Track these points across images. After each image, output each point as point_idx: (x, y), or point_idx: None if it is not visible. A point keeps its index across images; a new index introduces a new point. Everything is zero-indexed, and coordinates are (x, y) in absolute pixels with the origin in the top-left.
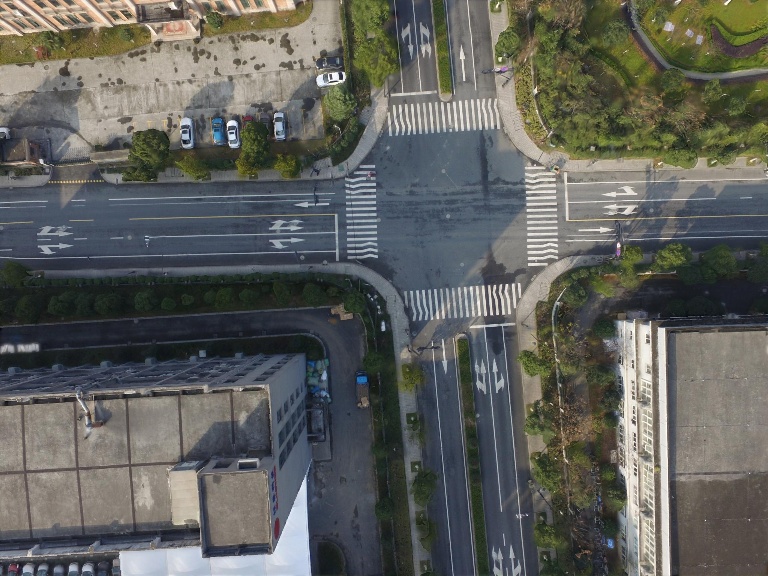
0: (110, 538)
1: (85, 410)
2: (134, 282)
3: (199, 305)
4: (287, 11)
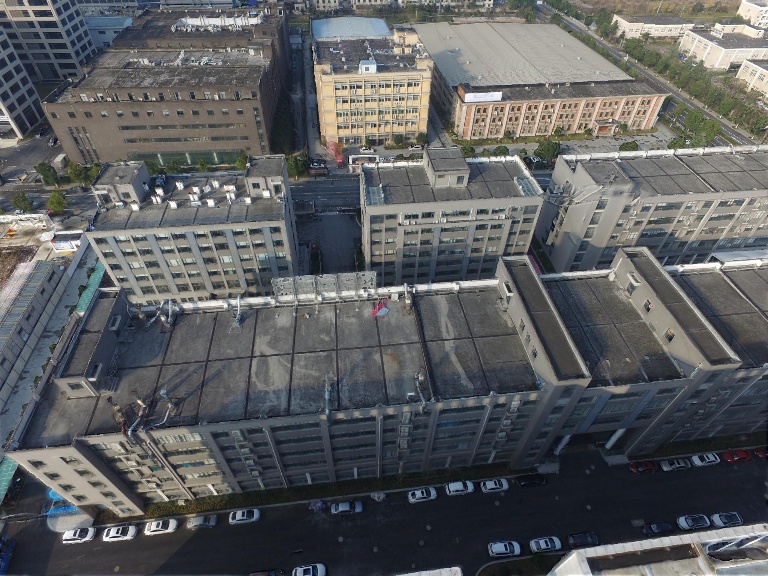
0: None
1: (734, 153)
2: None
3: None
4: (648, 129)
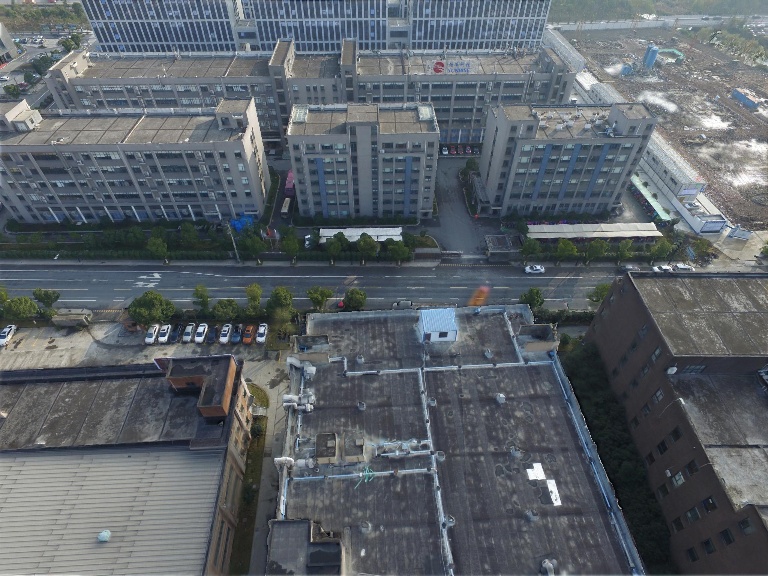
0: (85, 116)
1: (59, 142)
2: None
3: None
4: None
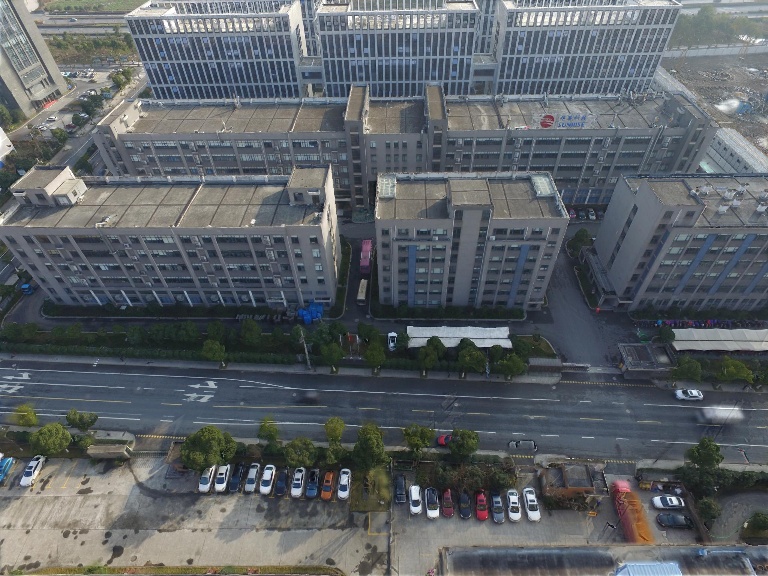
0: (134, 184)
1: (104, 223)
2: None
3: None
4: None
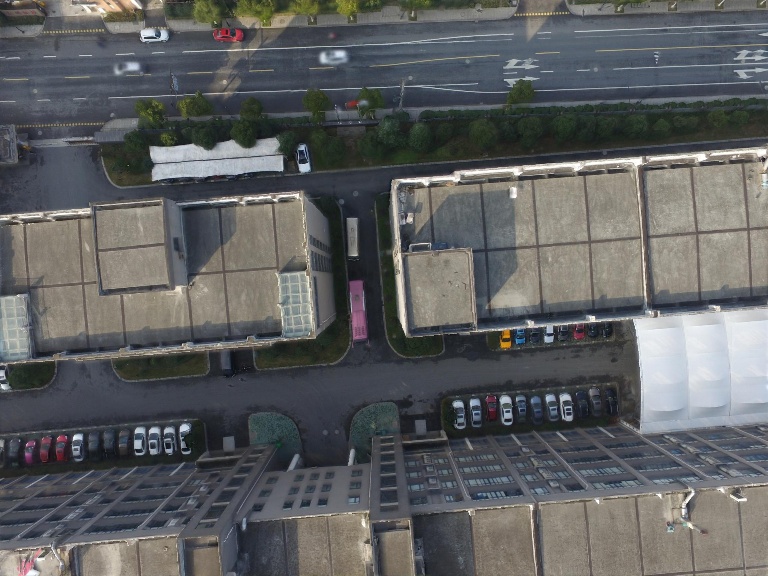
0: None
1: (765, 167)
2: (616, 109)
3: (669, 135)
4: None
